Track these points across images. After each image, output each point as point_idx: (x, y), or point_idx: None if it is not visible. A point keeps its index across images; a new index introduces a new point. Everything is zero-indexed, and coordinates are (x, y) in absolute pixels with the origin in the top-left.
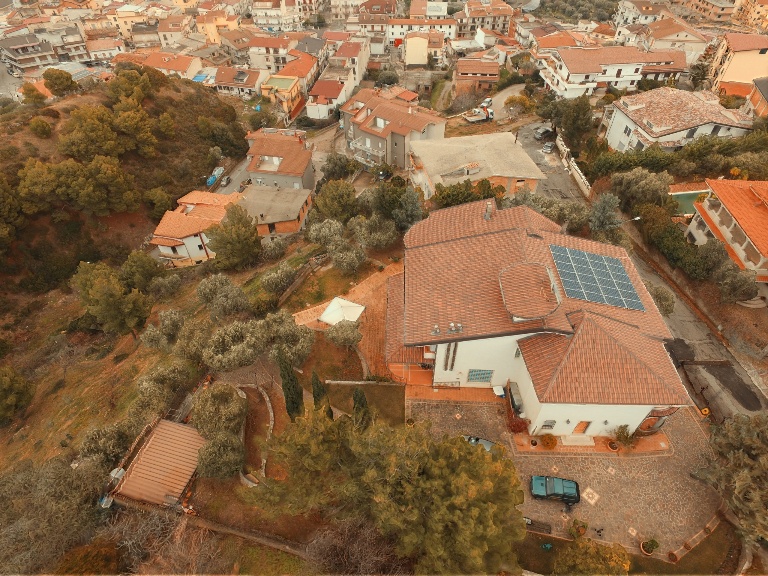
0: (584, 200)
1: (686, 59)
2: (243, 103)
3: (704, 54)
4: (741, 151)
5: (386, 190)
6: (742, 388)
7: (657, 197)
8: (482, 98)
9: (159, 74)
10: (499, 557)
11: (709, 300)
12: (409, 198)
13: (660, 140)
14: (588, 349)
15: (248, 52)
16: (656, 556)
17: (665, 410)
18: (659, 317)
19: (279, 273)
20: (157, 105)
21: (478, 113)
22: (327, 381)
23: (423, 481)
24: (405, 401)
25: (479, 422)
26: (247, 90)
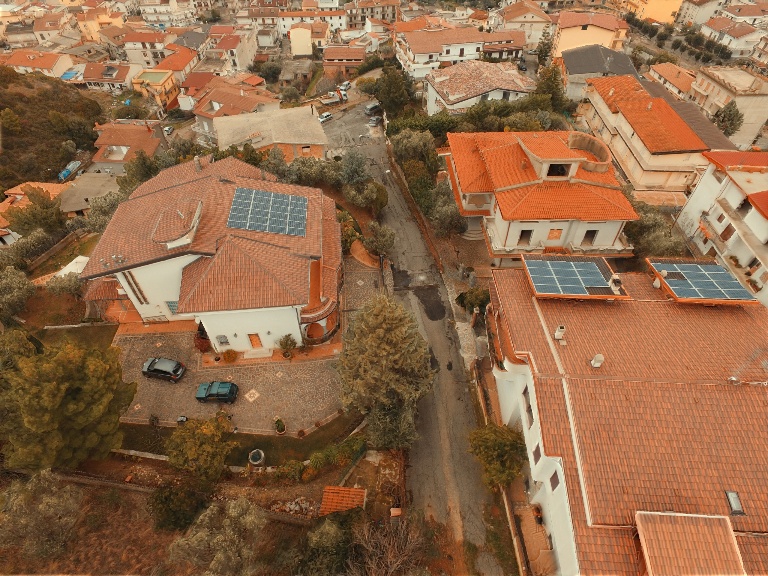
0: (390, 165)
1: (526, 38)
2: (111, 98)
3: (543, 33)
4: (516, 112)
5: (148, 158)
6: (436, 304)
7: (420, 154)
8: (343, 82)
9: (7, 70)
10: (94, 435)
11: (430, 235)
12: (162, 163)
13: (455, 107)
14: (225, 266)
15: (124, 48)
16: (289, 434)
17: (314, 317)
18: (318, 240)
19: (29, 239)
20: (3, 101)
21: (333, 96)
22: (45, 327)
23: (7, 373)
24: (114, 337)
25: (176, 348)
26: (118, 85)
